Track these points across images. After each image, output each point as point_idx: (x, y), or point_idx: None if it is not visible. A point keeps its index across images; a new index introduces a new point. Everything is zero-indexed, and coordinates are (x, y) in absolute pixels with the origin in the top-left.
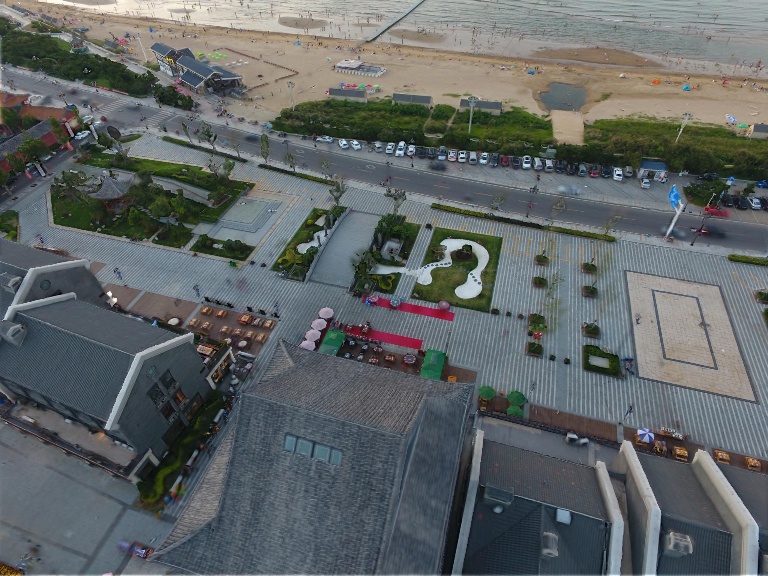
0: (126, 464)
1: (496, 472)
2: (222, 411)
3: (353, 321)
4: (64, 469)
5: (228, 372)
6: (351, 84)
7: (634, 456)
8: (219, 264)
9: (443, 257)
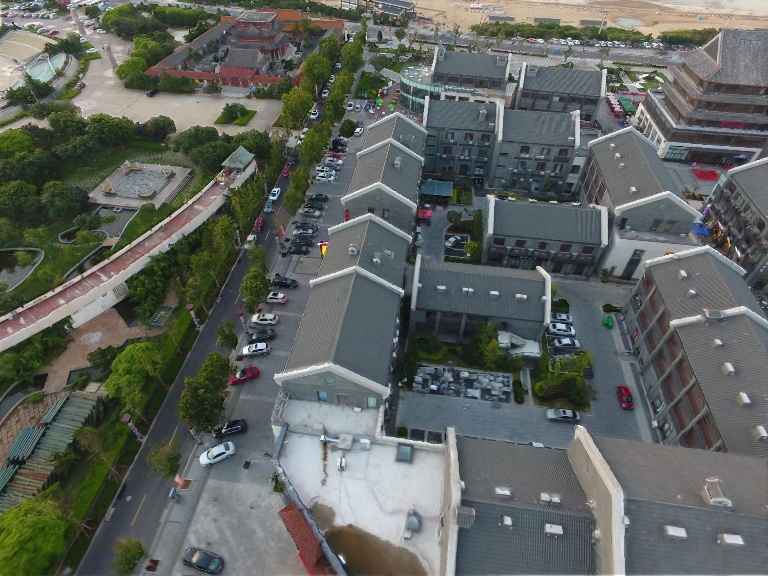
0: None
1: None
2: None
3: None
4: None
5: None
6: None
7: None
8: None
9: (640, 79)
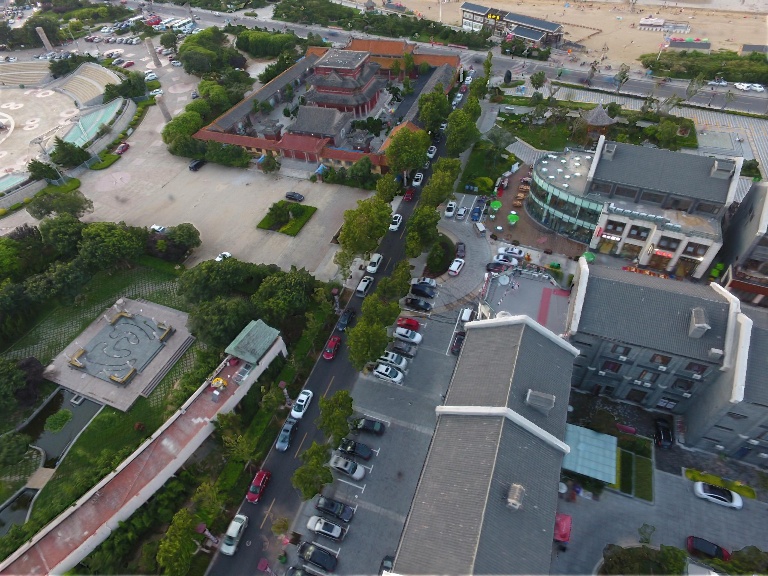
0: None
1: None
2: None
3: None
4: None
5: None
6: (677, 38)
7: None
8: (740, 180)
9: None
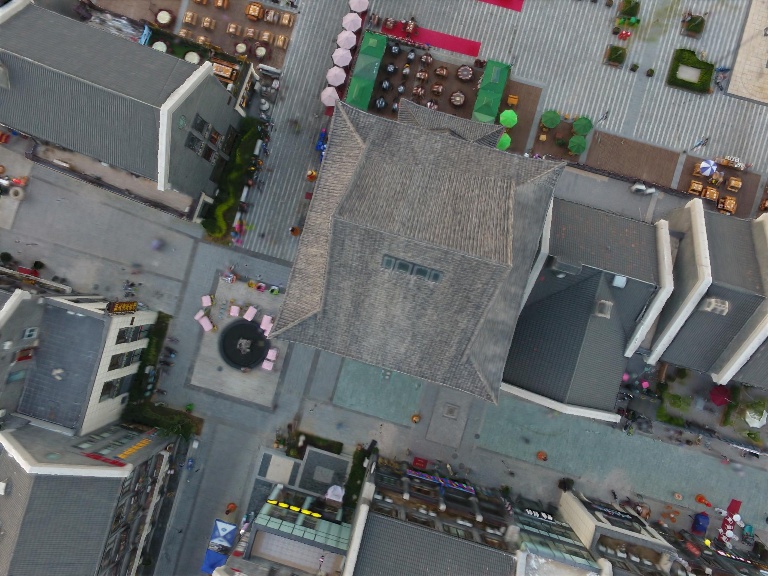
0: (186, 210)
1: (563, 238)
2: (260, 142)
3: (393, 13)
4: (121, 206)
5: (253, 92)
6: None
7: (702, 219)
8: None
9: None
